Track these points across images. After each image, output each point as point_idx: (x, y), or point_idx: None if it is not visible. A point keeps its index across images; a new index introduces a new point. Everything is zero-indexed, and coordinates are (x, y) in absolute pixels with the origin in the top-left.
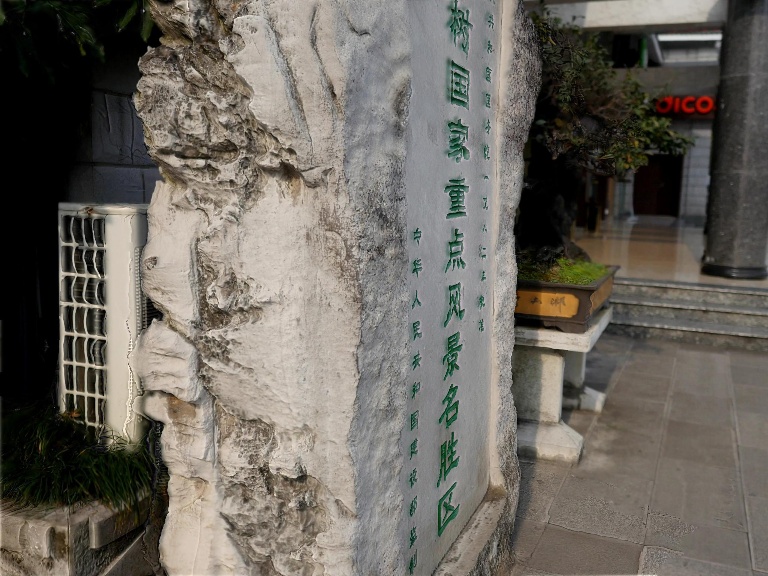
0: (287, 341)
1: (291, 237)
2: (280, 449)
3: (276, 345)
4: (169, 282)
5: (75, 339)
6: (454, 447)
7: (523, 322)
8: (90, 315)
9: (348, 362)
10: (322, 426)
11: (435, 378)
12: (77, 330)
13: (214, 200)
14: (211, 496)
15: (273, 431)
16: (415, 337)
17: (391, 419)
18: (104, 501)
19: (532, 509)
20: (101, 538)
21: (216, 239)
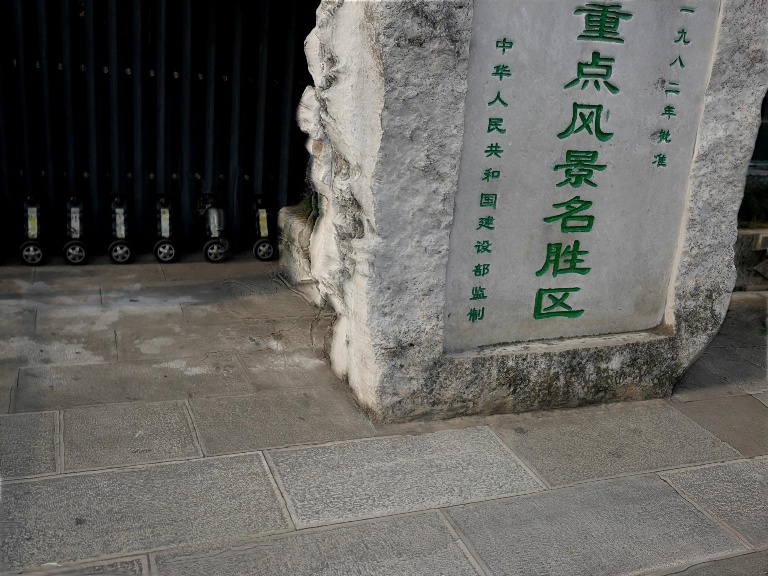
0: (346, 101)
1: (353, 27)
2: None
3: (342, 103)
4: (310, 59)
5: None
6: (580, 255)
7: None
8: None
9: (377, 121)
10: (363, 165)
11: (534, 177)
12: None
13: (331, 2)
14: (330, 210)
15: None
16: (492, 130)
17: (434, 181)
18: None
19: (752, 382)
20: None
21: (323, 28)
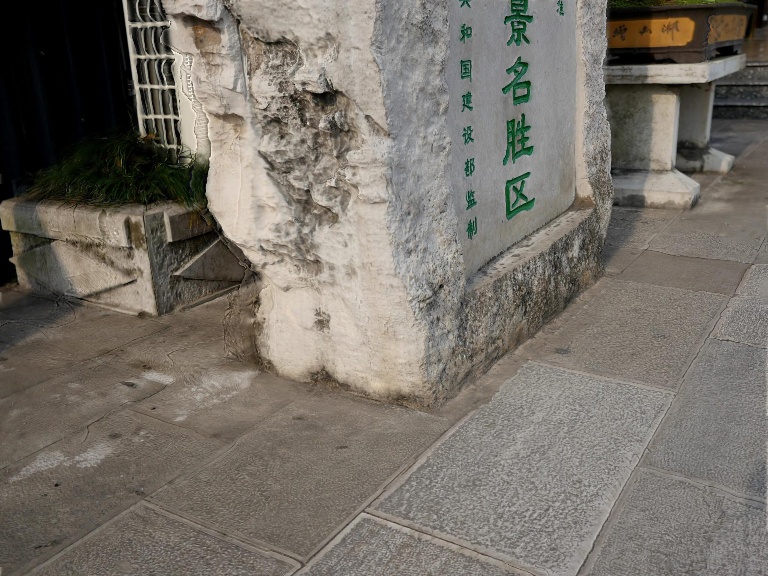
0: None
1: None
2: (306, 66)
3: None
4: None
5: (147, 61)
6: (525, 132)
7: (631, 59)
8: (157, 32)
9: None
10: (344, 32)
11: (493, 34)
12: (147, 51)
13: None
14: (248, 134)
15: (298, 49)
16: None
17: (429, 44)
18: (179, 201)
19: (631, 240)
20: (177, 233)
21: None
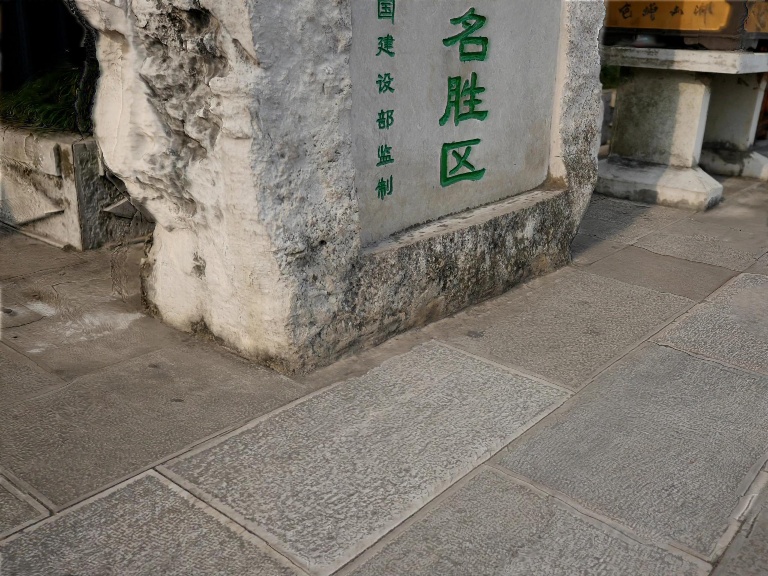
0: None
1: None
2: None
3: None
4: None
5: None
6: (477, 94)
7: (660, 42)
8: None
9: None
10: None
11: None
12: None
13: None
14: (129, 54)
15: None
16: None
17: None
18: None
19: (620, 234)
20: None
21: None
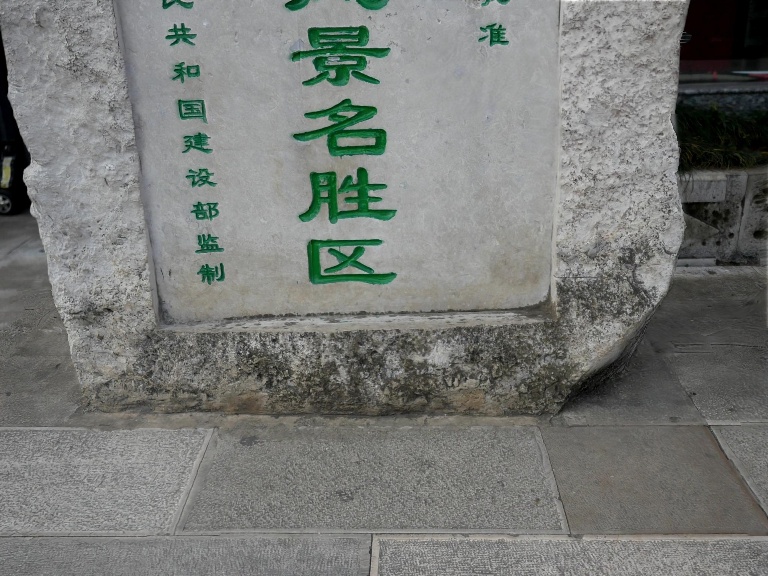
0: None
1: None
2: None
3: None
4: None
5: None
6: (372, 191)
7: None
8: None
9: None
10: None
11: (260, 73)
12: None
13: None
14: None
15: None
16: (171, 5)
17: (93, 84)
18: None
19: (738, 405)
20: None
21: None
